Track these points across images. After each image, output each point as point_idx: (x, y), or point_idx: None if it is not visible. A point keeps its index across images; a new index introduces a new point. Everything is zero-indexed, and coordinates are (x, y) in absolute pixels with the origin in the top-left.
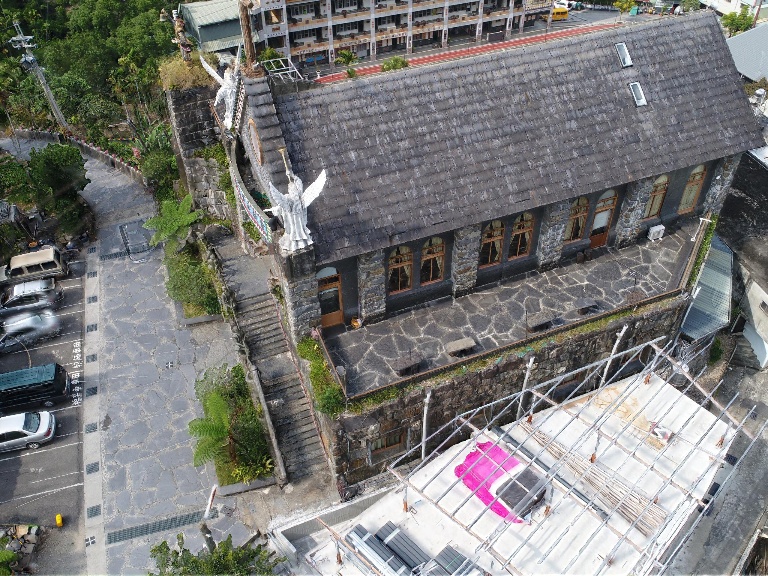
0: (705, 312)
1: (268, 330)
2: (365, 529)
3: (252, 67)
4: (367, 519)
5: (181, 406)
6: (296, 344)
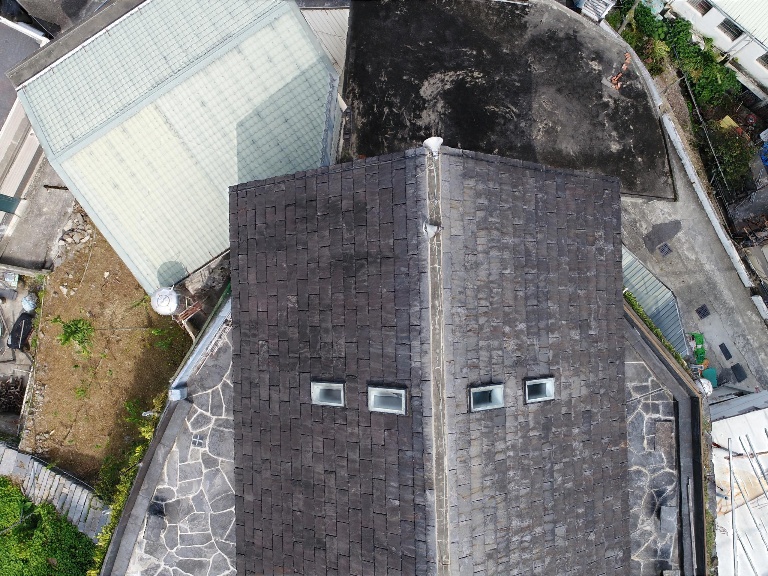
0: (653, 313)
1: None
2: None
3: None
4: None
5: None
6: None
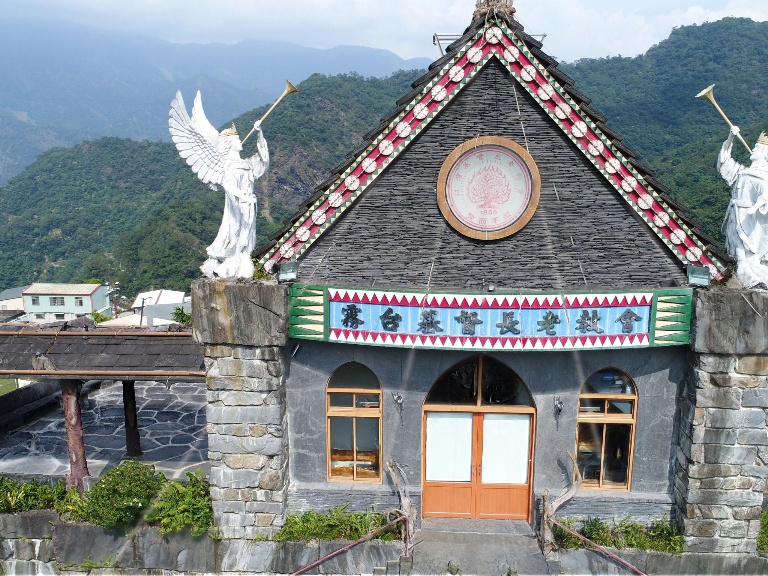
0: None
1: None
2: None
3: (507, 1)
4: None
5: None
6: (757, 544)
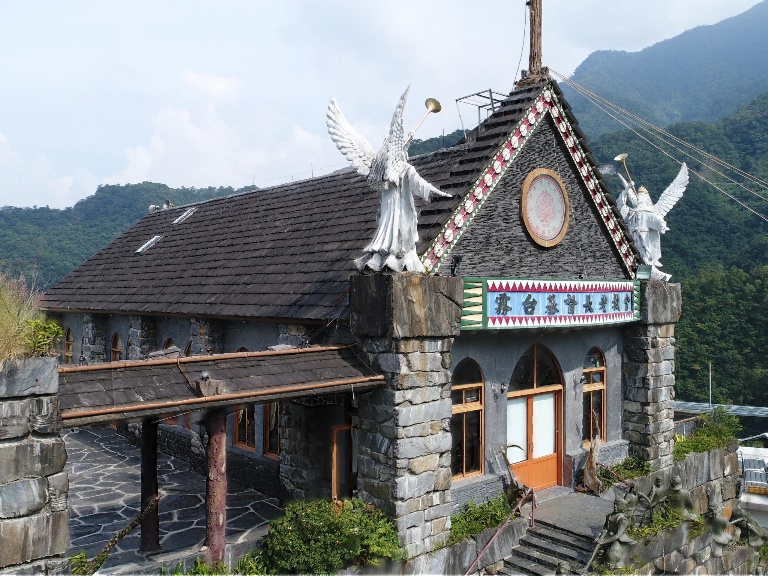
0: None
1: None
2: None
3: None
4: (761, 502)
5: None
6: None
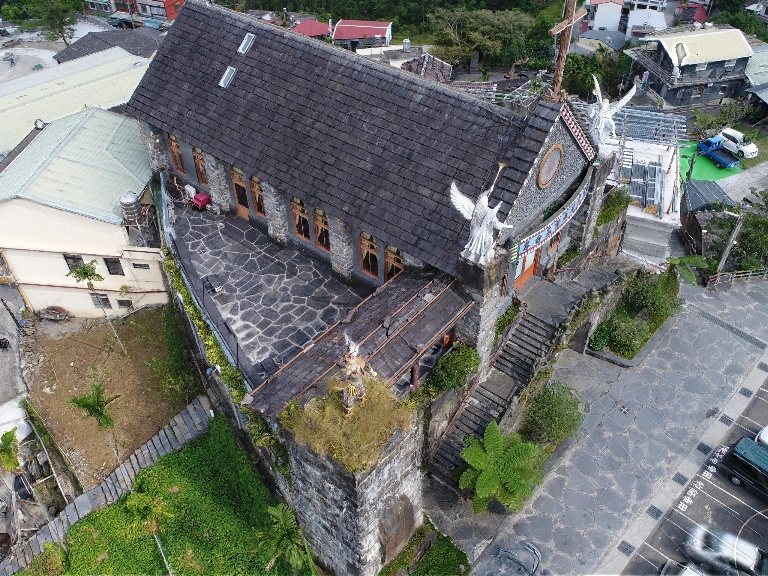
0: None
1: (577, 287)
2: (648, 201)
3: None
4: (635, 214)
5: (649, 374)
6: None
